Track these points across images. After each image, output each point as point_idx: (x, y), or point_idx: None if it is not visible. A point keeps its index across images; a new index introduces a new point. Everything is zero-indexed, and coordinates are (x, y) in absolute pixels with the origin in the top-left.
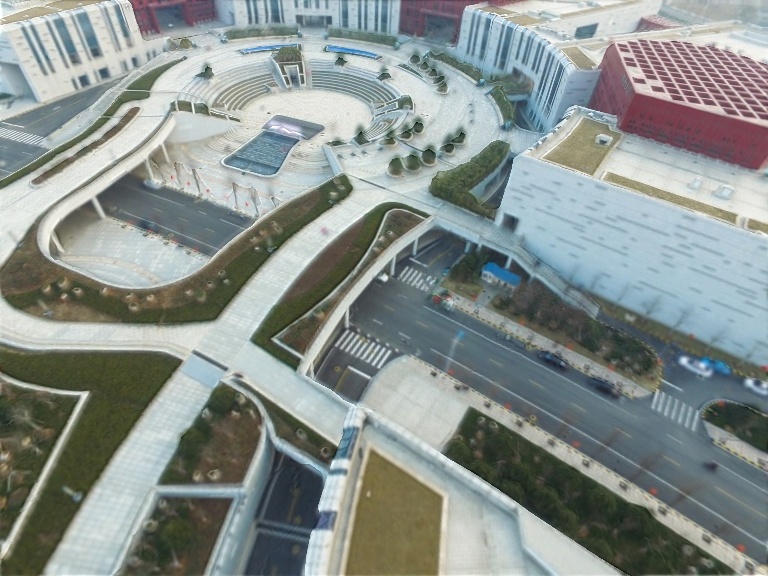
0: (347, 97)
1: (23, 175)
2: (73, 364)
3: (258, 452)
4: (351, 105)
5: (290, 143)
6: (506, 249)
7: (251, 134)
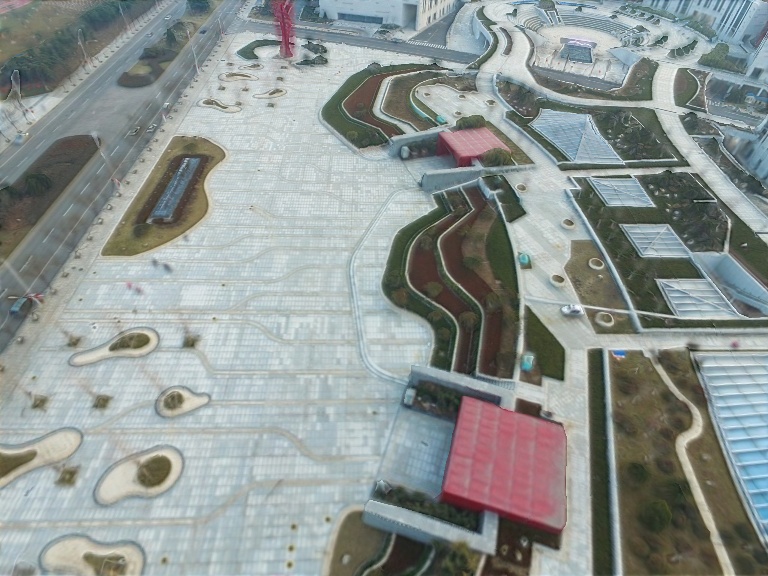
0: (591, 30)
1: (494, 52)
2: (611, 109)
3: None
4: (598, 34)
5: None
6: (760, 84)
7: (559, 46)
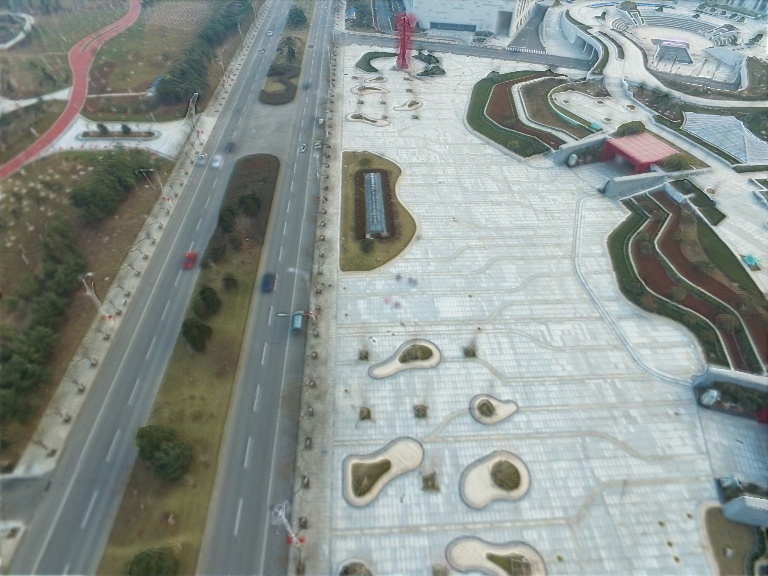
0: (675, 30)
1: (608, 56)
2: None
3: None
4: (684, 33)
5: None
6: None
7: (654, 47)
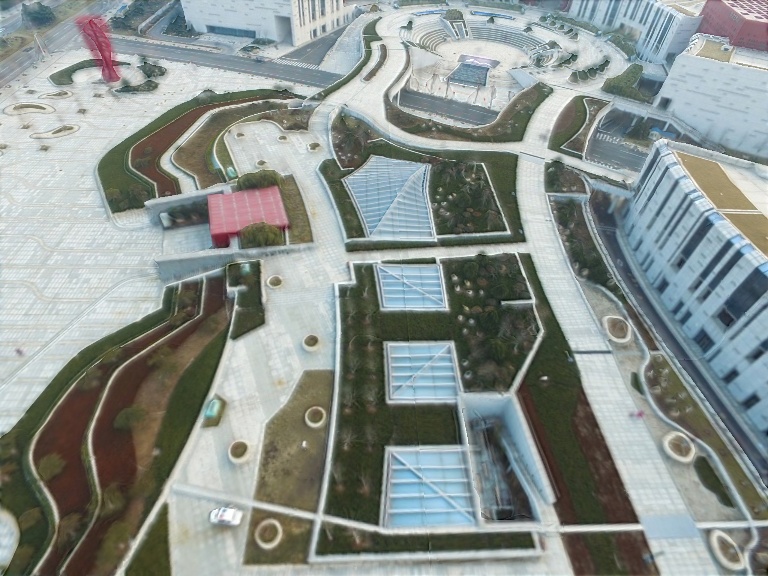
0: (501, 45)
1: (353, 77)
2: (463, 155)
3: (586, 185)
4: (508, 50)
5: (484, 70)
6: (666, 117)
7: (454, 65)
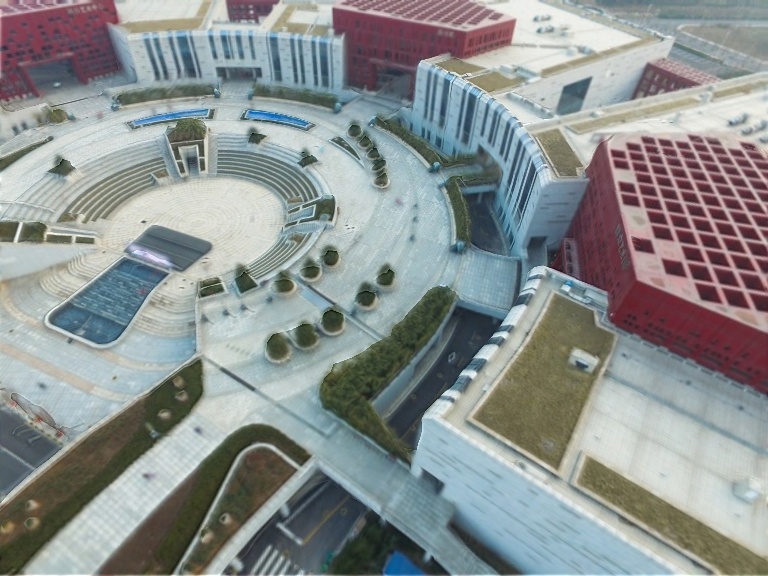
0: (259, 189)
1: None
2: None
3: None
4: (260, 203)
5: (153, 280)
6: (421, 540)
7: (104, 263)
